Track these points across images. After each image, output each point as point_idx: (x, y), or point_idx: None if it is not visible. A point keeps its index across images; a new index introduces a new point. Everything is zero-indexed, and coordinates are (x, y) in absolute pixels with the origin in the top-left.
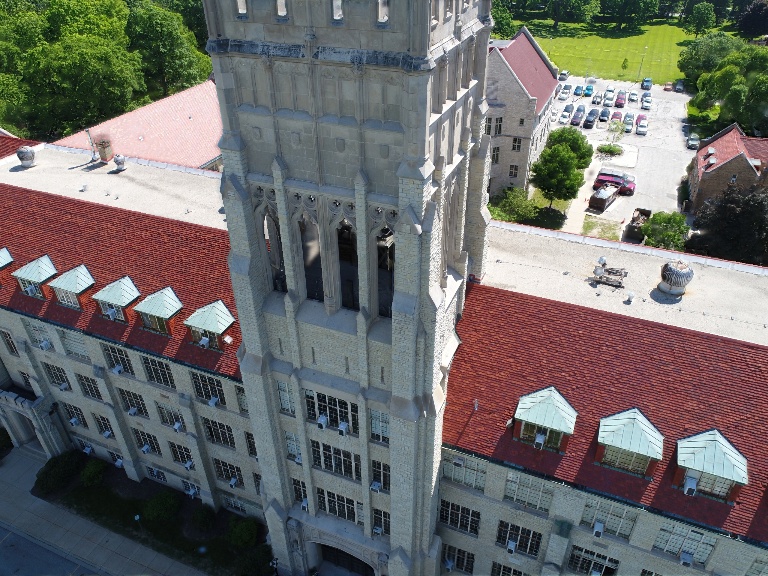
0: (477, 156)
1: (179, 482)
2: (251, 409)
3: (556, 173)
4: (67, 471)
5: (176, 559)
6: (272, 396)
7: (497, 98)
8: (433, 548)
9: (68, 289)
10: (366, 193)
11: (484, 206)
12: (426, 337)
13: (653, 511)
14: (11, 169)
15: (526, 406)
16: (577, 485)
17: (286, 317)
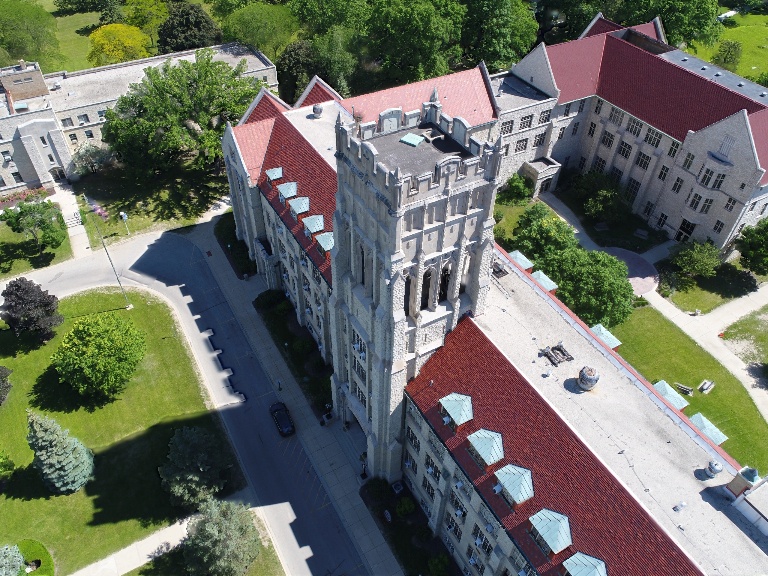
0: (480, 248)
1: (317, 338)
2: (331, 321)
3: (758, 246)
4: (272, 301)
5: (294, 376)
6: (340, 321)
7: (728, 155)
8: (392, 445)
9: (294, 209)
10: (378, 252)
11: (485, 276)
12: (391, 333)
13: (477, 490)
14: (307, 116)
15: (449, 398)
16: (452, 454)
17: (348, 287)
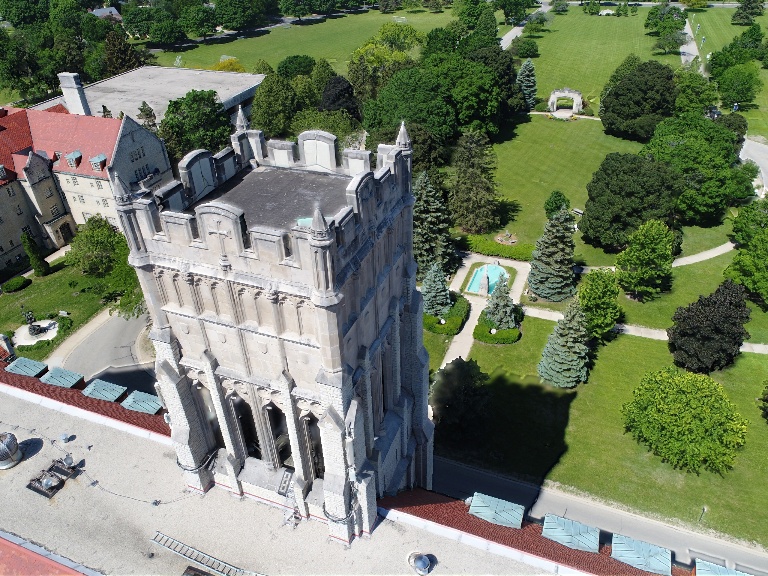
0: None
1: None
2: None
3: None
4: None
5: None
6: None
7: None
8: None
9: None
10: None
11: None
12: None
13: None
14: None
15: None
16: None
17: None
